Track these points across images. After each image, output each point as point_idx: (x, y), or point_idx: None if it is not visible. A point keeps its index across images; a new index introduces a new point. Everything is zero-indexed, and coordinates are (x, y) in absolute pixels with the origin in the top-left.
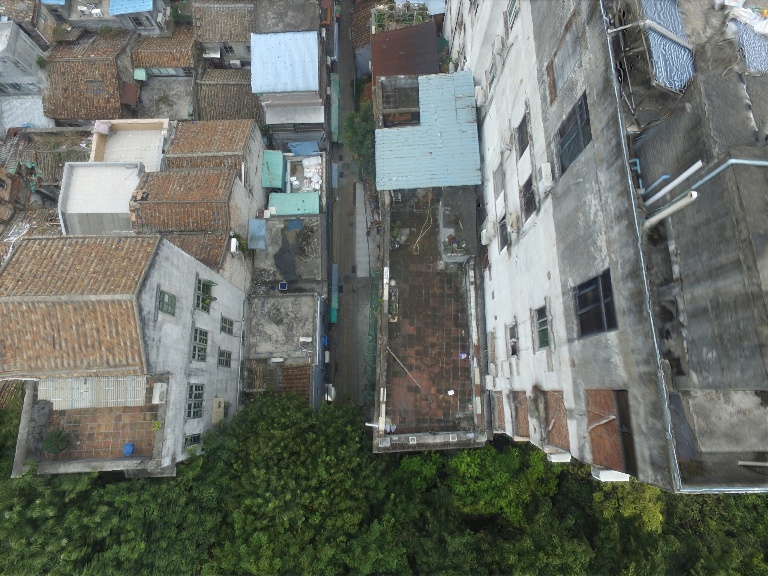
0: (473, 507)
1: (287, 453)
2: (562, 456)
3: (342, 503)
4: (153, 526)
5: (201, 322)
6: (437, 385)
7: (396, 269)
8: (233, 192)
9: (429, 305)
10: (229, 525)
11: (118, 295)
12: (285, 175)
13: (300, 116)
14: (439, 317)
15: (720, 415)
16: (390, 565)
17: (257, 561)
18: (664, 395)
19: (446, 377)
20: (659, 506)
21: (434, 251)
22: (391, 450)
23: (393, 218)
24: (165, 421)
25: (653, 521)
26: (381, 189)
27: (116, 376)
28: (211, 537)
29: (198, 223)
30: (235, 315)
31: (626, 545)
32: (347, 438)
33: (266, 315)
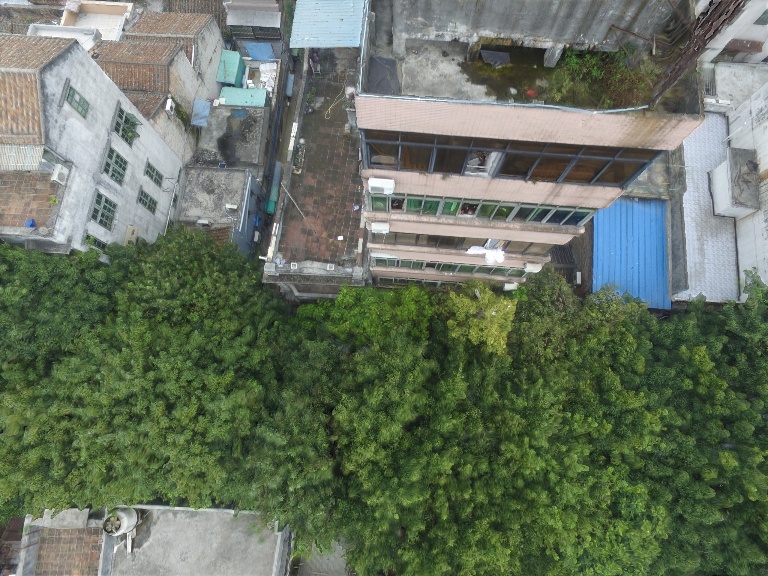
0: (341, 329)
1: (180, 266)
2: (381, 224)
3: (223, 312)
4: (43, 293)
5: (120, 148)
6: (329, 231)
7: (307, 130)
8: (176, 62)
9: (332, 163)
10: (116, 313)
11: (25, 69)
12: (242, 77)
13: (258, 20)
14: (340, 174)
15: (425, 76)
16: (253, 361)
17: (129, 332)
18: (364, 33)
19: (338, 225)
20: (512, 347)
21: (344, 118)
22: (279, 281)
23: (311, 87)
24: (63, 201)
25: (490, 338)
26: (293, 46)
27: (18, 144)
28: (96, 316)
29: (140, 83)
30: (167, 173)
31: (470, 367)
32: (244, 273)
33: (200, 185)
